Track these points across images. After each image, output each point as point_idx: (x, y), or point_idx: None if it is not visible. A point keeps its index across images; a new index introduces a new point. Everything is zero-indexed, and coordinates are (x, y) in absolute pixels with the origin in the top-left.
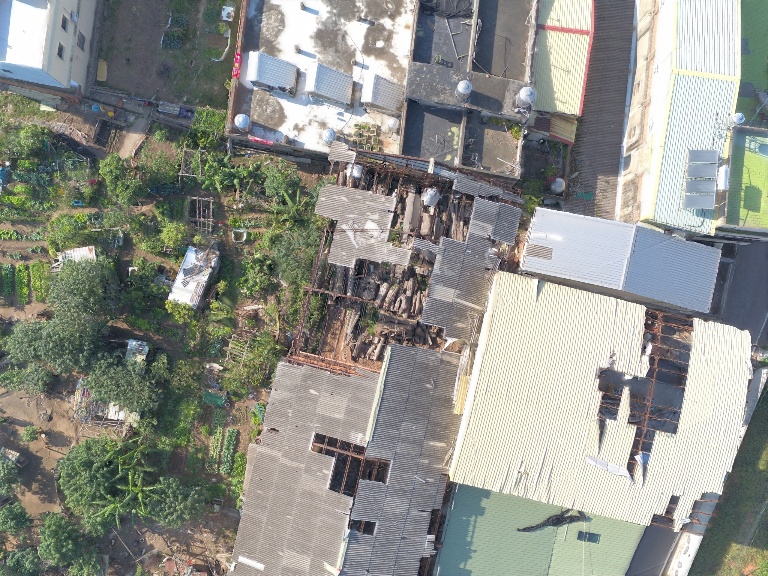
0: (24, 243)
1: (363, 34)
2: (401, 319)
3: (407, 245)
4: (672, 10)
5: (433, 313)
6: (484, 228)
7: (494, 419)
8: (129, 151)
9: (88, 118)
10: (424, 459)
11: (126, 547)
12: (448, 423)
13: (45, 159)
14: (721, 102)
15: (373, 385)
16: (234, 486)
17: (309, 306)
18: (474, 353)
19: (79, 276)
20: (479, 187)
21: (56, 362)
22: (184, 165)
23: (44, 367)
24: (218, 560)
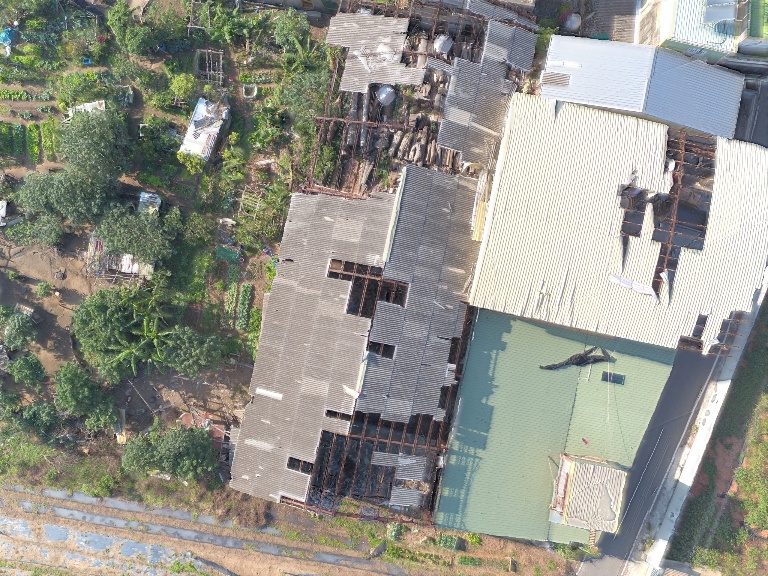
0: (34, 103)
1: None
2: None
3: (420, 93)
4: None
5: (449, 136)
6: (499, 51)
7: (514, 238)
8: (137, 9)
9: None
10: (443, 285)
11: (142, 398)
12: (467, 249)
13: (53, 19)
14: None
15: (389, 206)
16: (250, 341)
17: (322, 156)
18: (492, 179)
19: (89, 122)
20: (493, 9)
21: (68, 211)
22: (193, 18)
23: (56, 218)
24: (235, 416)
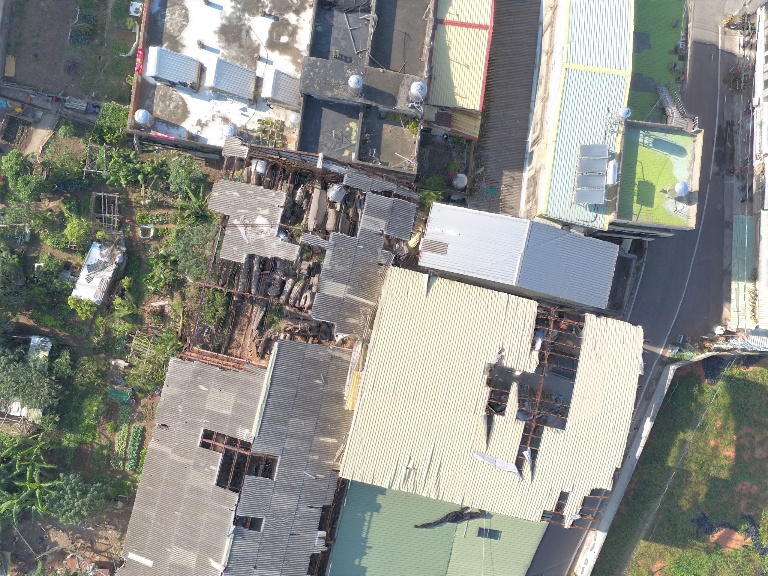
0: None
1: (267, 29)
2: (306, 315)
3: None
4: (565, 4)
5: (323, 308)
6: (377, 223)
7: (381, 415)
8: (37, 147)
9: None
10: (314, 455)
11: (27, 544)
12: (339, 419)
13: None
14: (612, 97)
15: (260, 381)
16: None
17: (214, 302)
18: (367, 349)
19: None
20: (371, 182)
21: None
22: (89, 161)
23: None
24: None
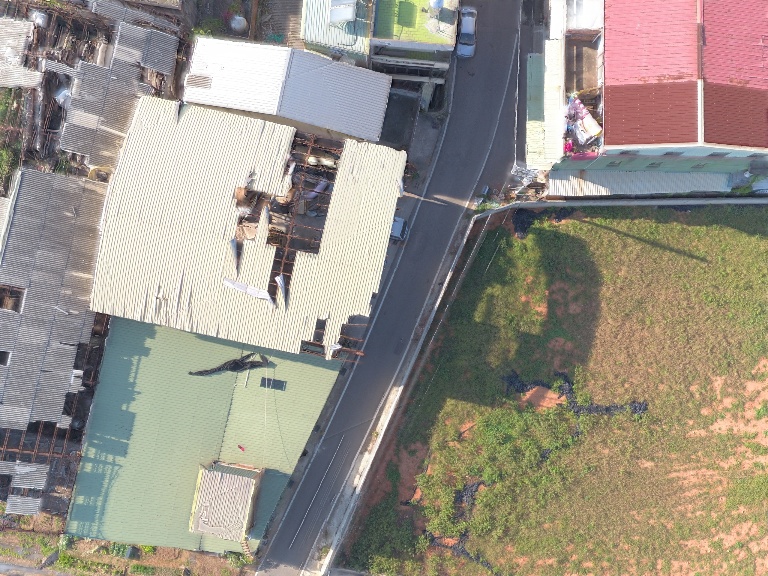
0: None
1: None
2: None
3: None
4: None
5: (74, 140)
6: (132, 55)
7: (127, 242)
8: None
9: None
10: (66, 290)
11: None
12: (95, 254)
13: None
14: None
15: (3, 211)
16: None
17: (2, 162)
18: None
19: None
20: (124, 12)
21: None
22: None
23: None
24: None
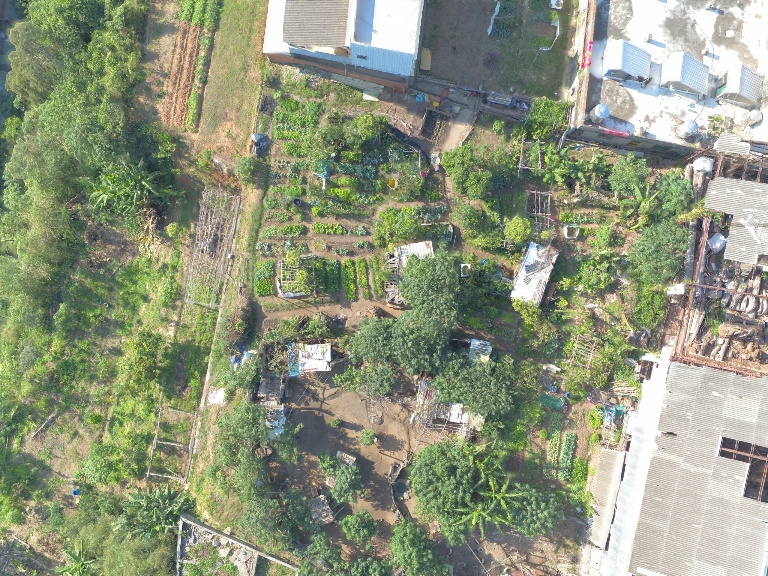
0: (348, 238)
1: (713, 23)
2: (749, 319)
3: None
4: None
5: None
6: None
7: None
8: (455, 143)
9: (412, 108)
10: None
11: (477, 557)
12: None
13: (369, 150)
14: None
15: None
16: (573, 493)
17: (653, 305)
18: None
19: (437, 272)
20: None
21: (409, 362)
22: (522, 158)
23: (392, 367)
24: (559, 570)
